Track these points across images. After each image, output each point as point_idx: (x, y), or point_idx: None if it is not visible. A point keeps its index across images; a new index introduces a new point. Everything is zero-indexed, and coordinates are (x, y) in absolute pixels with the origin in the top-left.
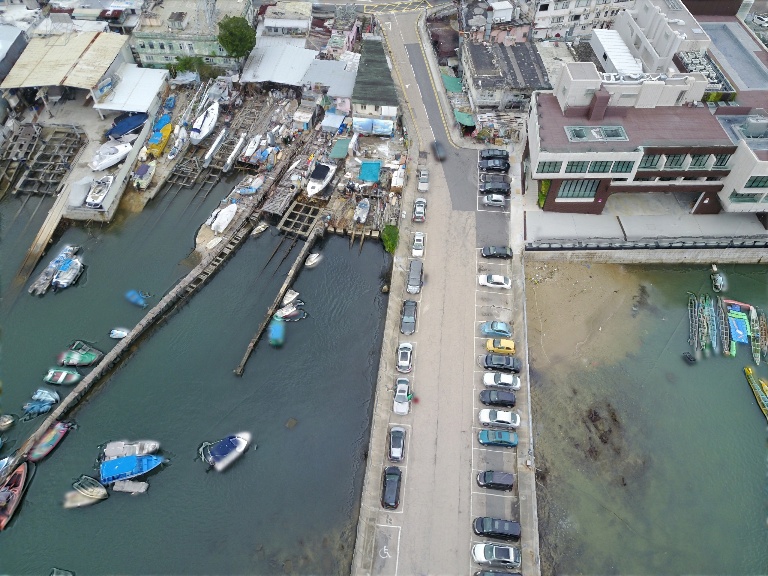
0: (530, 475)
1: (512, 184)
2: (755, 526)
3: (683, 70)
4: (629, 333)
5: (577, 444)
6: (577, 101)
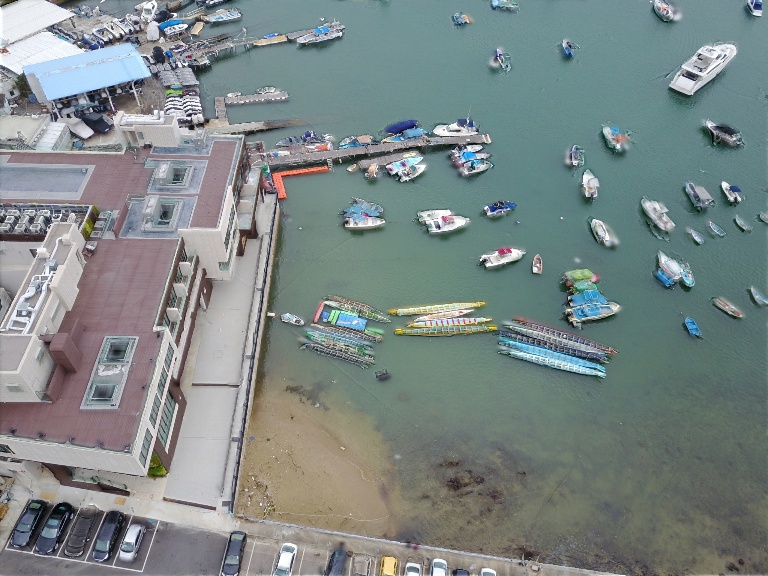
0: (548, 569)
1: (102, 507)
2: (542, 380)
3: (18, 237)
4: (349, 420)
5: (488, 509)
6: (40, 377)
